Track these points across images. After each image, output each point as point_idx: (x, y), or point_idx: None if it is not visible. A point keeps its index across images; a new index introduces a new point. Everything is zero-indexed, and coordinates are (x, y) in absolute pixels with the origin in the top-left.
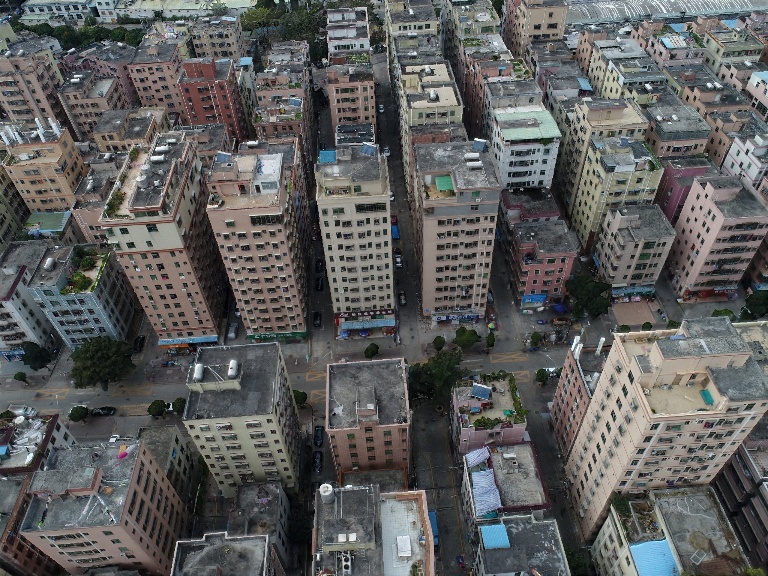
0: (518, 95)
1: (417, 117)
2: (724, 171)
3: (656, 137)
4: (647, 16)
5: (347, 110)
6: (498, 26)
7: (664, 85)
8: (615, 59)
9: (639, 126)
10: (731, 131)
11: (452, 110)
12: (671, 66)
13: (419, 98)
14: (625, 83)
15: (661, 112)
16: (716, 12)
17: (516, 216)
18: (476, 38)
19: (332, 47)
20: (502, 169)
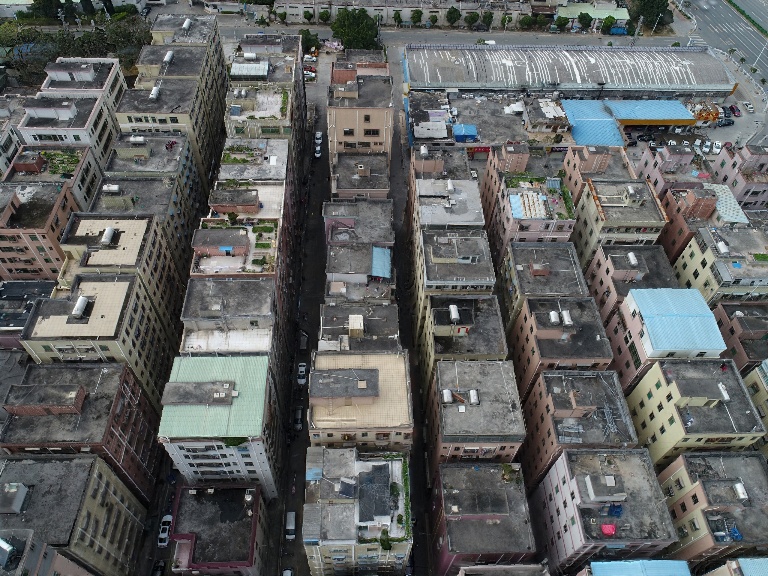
0: (227, 318)
1: (42, 350)
2: (548, 484)
3: (439, 426)
4: (552, 85)
5: (16, 260)
6: (287, 127)
7: (507, 270)
8: (433, 225)
9: (396, 430)
10: (569, 417)
11: (101, 344)
12: (523, 238)
13: (59, 308)
14: (429, 285)
15: (457, 375)
16: (646, 86)
17: (188, 547)
18: (249, 145)
19: (29, 136)
20: (175, 460)
